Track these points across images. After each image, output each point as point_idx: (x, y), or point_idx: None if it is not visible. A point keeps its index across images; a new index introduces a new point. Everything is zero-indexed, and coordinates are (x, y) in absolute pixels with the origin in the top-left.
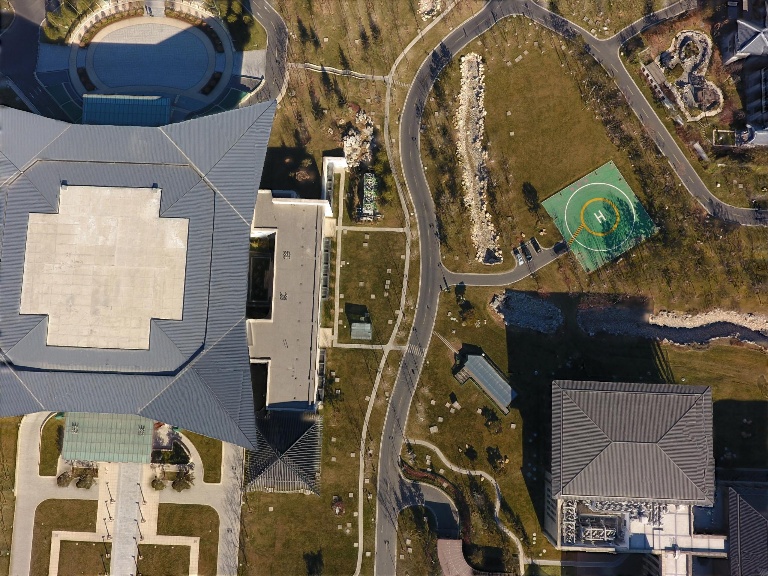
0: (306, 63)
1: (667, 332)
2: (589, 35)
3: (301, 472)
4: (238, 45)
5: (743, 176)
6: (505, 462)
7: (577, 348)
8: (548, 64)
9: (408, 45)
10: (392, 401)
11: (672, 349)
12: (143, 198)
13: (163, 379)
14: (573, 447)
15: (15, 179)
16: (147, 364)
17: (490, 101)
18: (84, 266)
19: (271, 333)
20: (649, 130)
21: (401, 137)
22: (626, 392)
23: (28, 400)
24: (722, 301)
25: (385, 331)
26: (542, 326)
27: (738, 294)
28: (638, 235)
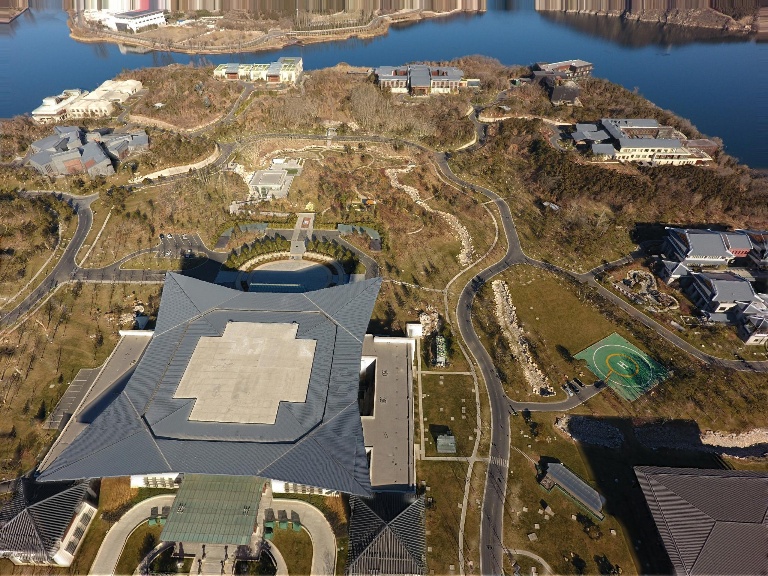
0: (391, 280)
1: (723, 451)
2: (571, 272)
3: (408, 547)
4: (347, 271)
5: (717, 337)
6: (618, 572)
7: (646, 460)
8: (550, 284)
9: (455, 276)
10: (484, 509)
11: (734, 462)
12: (285, 328)
13: (284, 446)
14: (680, 528)
15: (196, 319)
16: (271, 435)
17: (517, 302)
18: (234, 366)
19: (373, 427)
20: (634, 316)
21: (458, 320)
22: (706, 476)
23: (160, 462)
24: (755, 422)
25: (467, 446)
26: (607, 443)
27: (766, 417)
28: (658, 376)
